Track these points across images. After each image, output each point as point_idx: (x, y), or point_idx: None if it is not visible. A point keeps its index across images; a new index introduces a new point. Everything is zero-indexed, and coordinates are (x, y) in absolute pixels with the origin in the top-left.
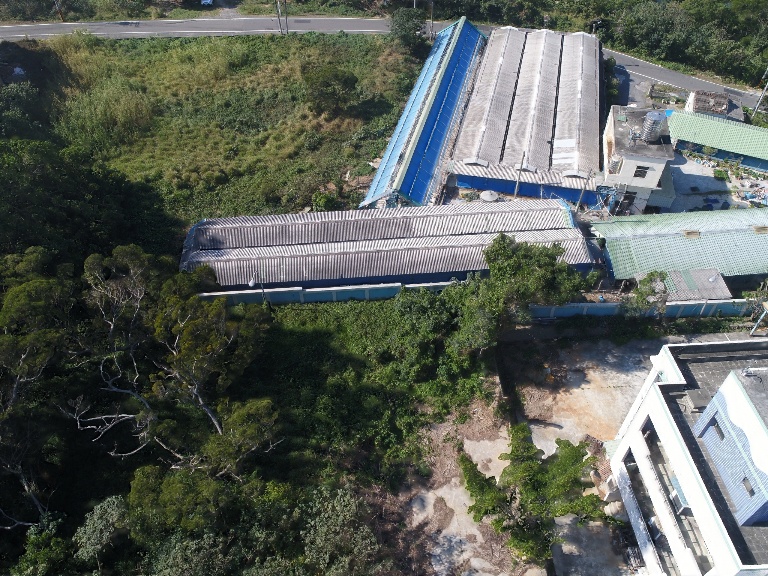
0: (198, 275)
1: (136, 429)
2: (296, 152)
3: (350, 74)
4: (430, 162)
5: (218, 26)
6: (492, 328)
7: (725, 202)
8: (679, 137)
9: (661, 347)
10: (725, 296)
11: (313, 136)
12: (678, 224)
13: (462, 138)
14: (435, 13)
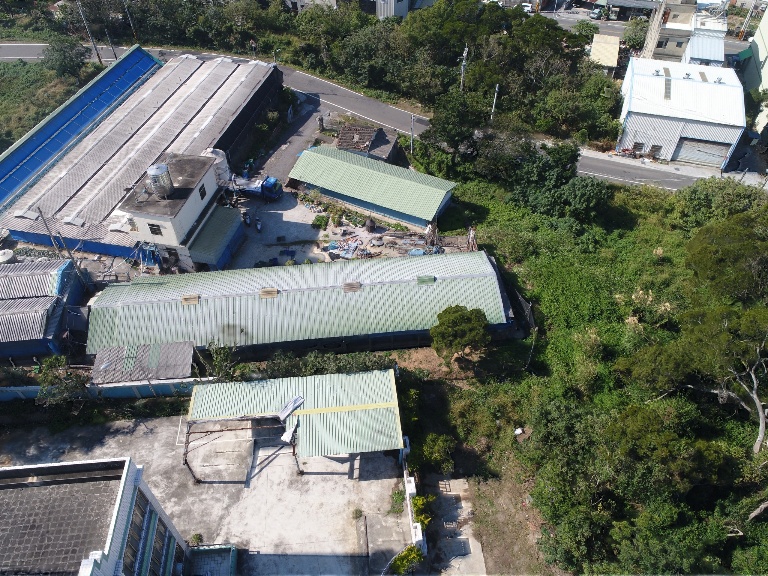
0: None
1: None
2: None
3: None
4: None
5: None
6: None
7: (292, 255)
8: None
9: (98, 435)
10: (182, 375)
11: None
12: (192, 287)
13: (36, 185)
14: (113, 40)
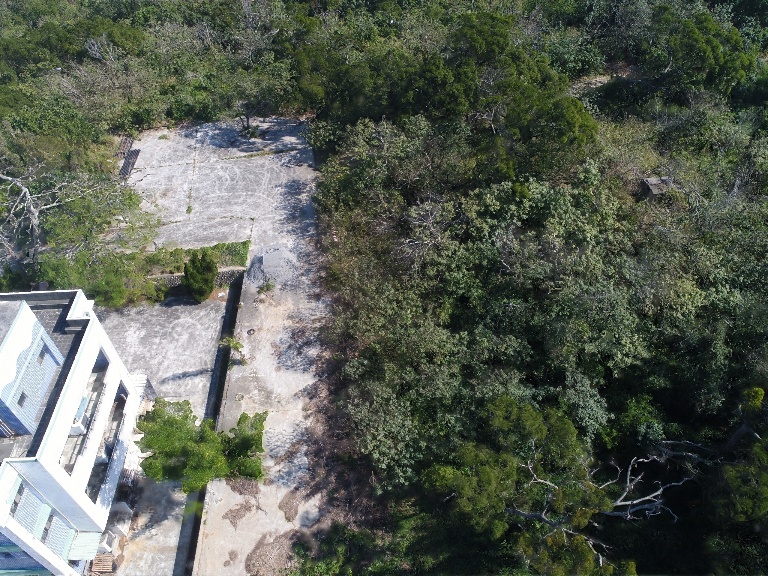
0: None
1: None
2: None
3: None
4: None
5: None
6: None
7: None
8: None
9: None
10: None
11: None
12: None
13: None
14: None
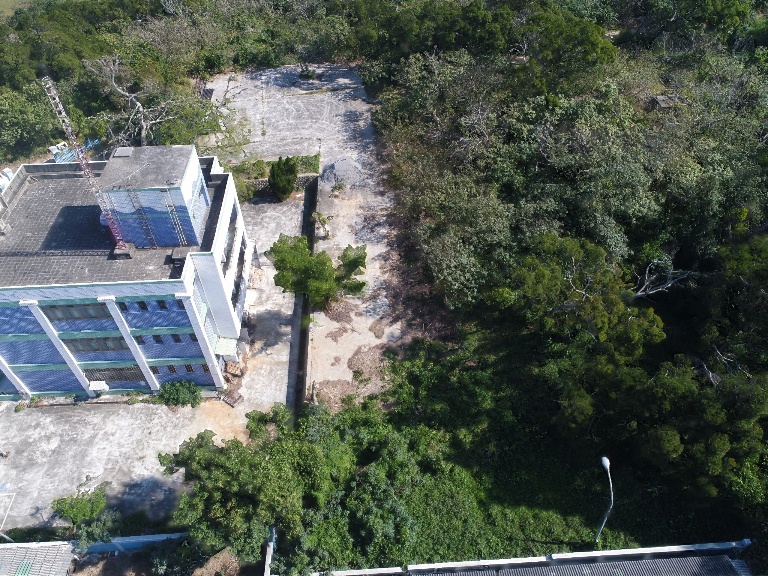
0: (664, 407)
1: (656, 363)
2: None
3: None
4: None
5: None
6: None
7: None
8: None
9: None
10: None
11: None
12: None
13: None
14: None
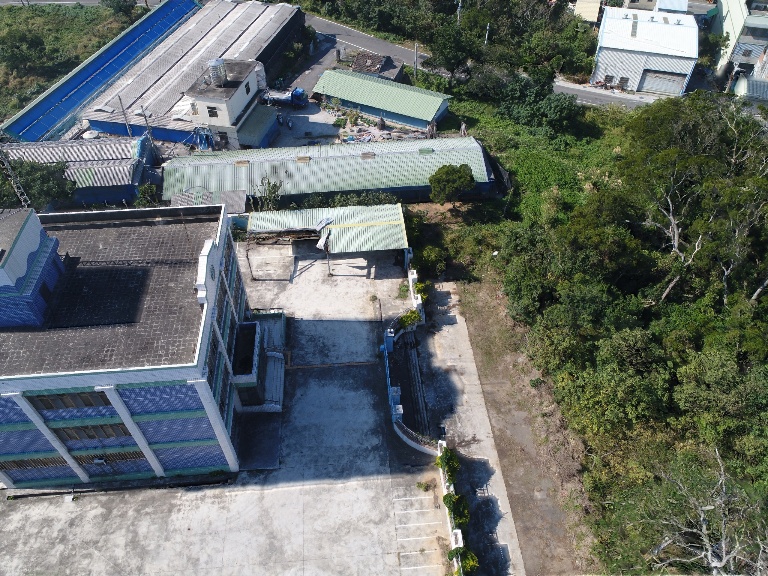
0: None
1: None
2: None
3: (33, 36)
4: (63, 109)
5: None
6: None
7: None
8: (323, 92)
9: None
10: (239, 211)
11: None
12: (242, 157)
13: (108, 90)
14: None
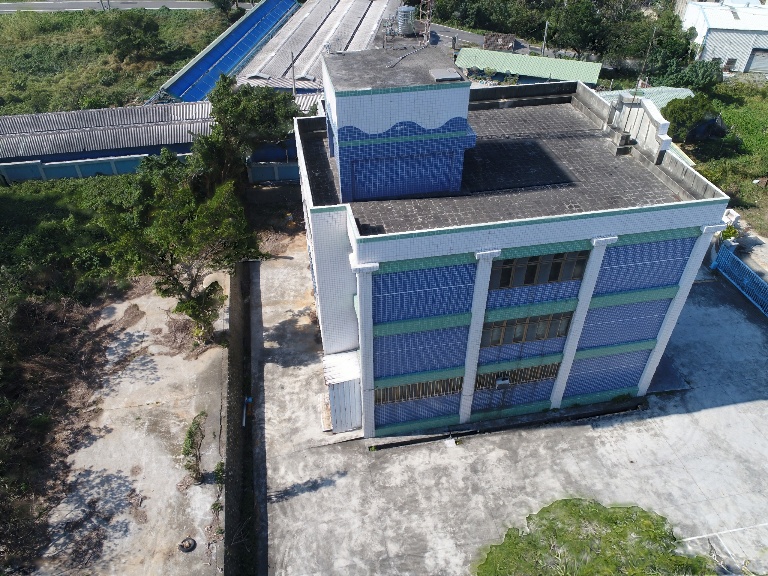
0: None
1: None
2: (88, 86)
3: (149, 19)
4: (212, 78)
5: (40, 6)
6: (203, 151)
7: None
8: (467, 66)
9: None
10: None
11: (109, 74)
12: None
13: (251, 63)
14: None
